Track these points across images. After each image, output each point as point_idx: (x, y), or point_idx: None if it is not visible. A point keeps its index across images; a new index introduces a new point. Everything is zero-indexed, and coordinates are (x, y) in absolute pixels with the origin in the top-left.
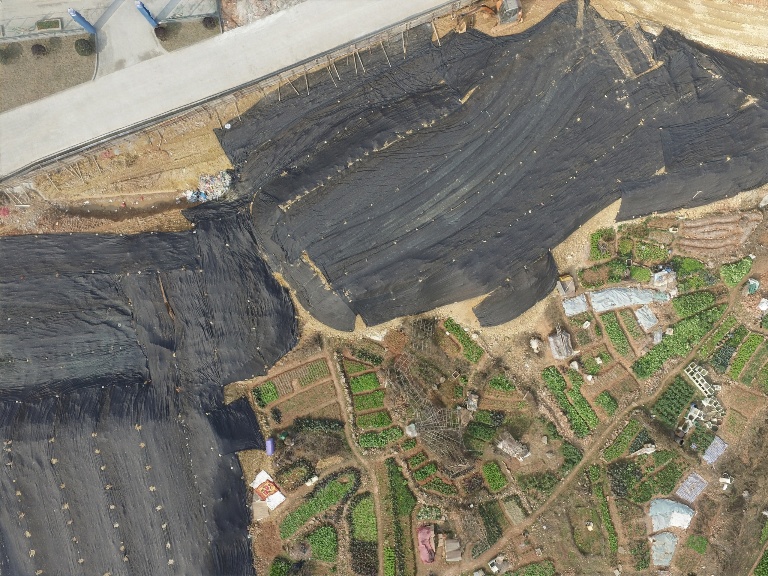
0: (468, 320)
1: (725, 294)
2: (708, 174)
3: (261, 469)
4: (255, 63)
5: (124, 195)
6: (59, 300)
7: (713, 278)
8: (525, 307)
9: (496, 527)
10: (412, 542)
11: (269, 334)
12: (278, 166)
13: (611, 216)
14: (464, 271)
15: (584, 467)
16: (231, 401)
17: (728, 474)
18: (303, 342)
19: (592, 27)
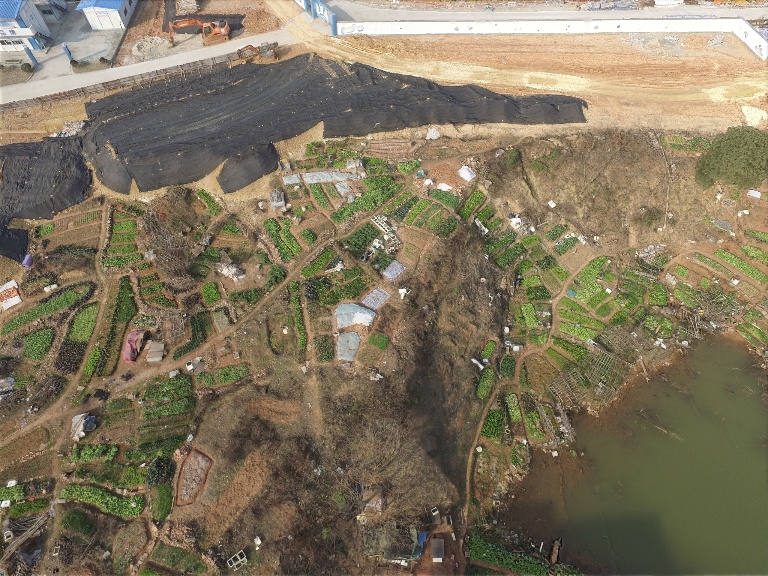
0: (215, 189)
1: (401, 178)
2: (379, 112)
3: (12, 279)
4: None
5: (11, 133)
6: None
7: (391, 169)
8: (254, 177)
9: (201, 331)
10: (121, 345)
11: (64, 189)
12: None
13: (320, 134)
14: (210, 149)
15: (287, 284)
16: (13, 228)
17: (406, 287)
18: (89, 200)
19: (317, 62)
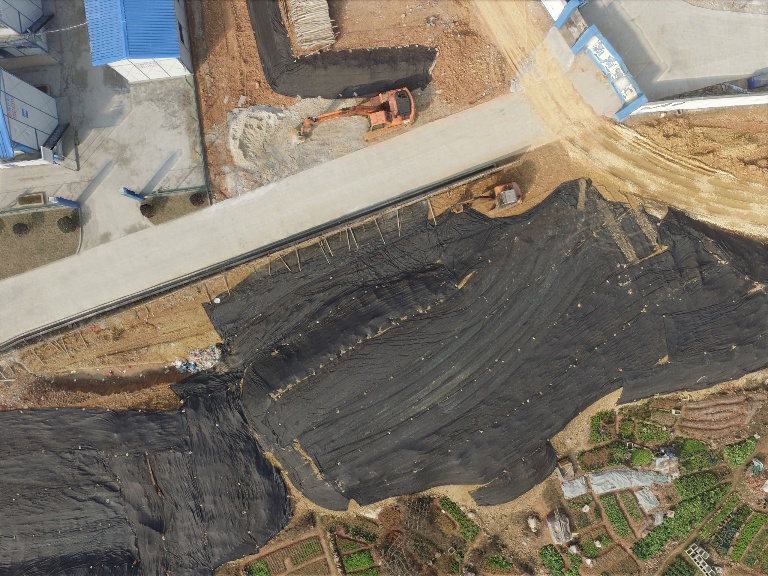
0: (464, 500)
1: (728, 475)
2: (712, 363)
3: None
4: (245, 236)
5: (111, 366)
6: (45, 476)
7: (716, 459)
8: (523, 491)
9: None
10: None
11: (260, 517)
12: (269, 342)
13: (612, 401)
14: (460, 462)
15: None
16: None
17: None
18: (295, 521)
19: (594, 209)
